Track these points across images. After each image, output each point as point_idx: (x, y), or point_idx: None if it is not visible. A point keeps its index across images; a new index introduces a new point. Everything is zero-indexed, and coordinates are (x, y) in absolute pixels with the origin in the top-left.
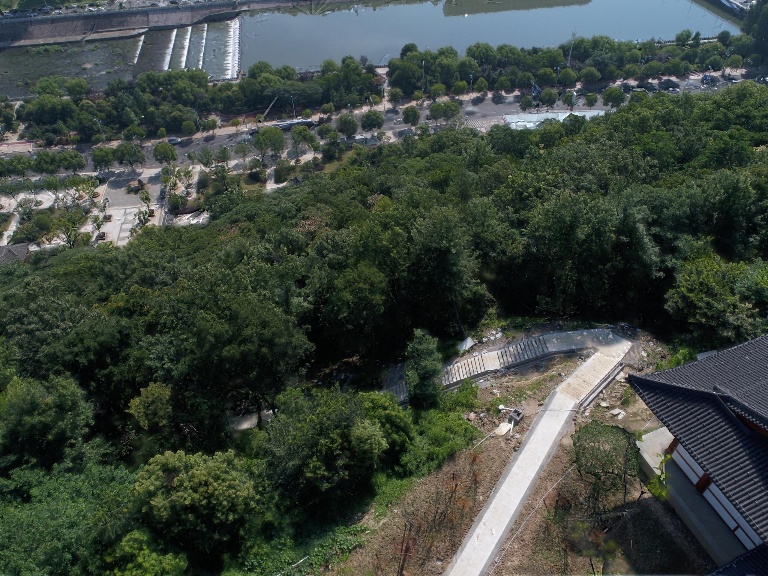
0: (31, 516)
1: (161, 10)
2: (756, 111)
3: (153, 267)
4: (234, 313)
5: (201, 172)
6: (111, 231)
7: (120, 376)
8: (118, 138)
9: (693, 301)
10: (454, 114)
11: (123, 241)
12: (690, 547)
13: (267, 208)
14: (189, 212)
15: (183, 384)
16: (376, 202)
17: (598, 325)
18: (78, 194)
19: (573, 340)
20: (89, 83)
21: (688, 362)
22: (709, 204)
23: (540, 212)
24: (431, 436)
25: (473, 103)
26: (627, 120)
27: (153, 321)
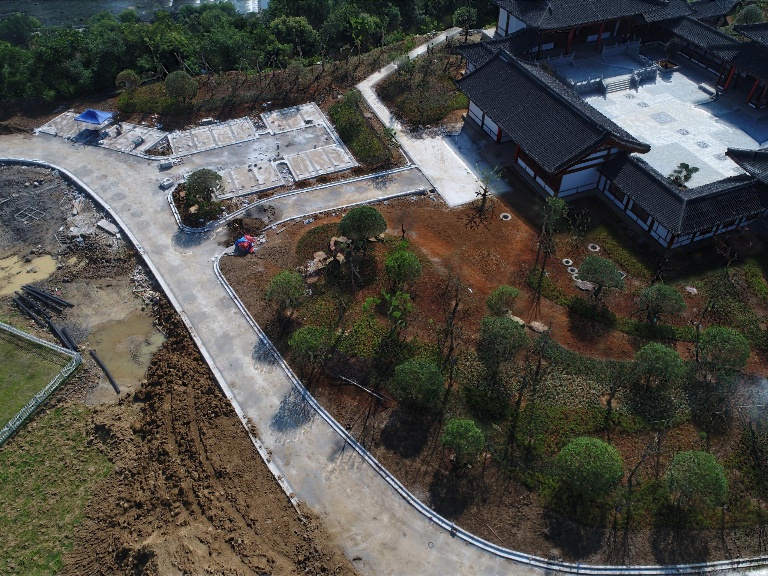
0: None
1: None
2: None
3: None
4: None
5: None
6: None
7: None
8: None
9: None
10: None
11: None
12: None
13: None
14: None
15: None
16: None
17: None
18: None
19: None
20: (139, 13)
21: None
22: None
23: None
24: None
25: None
26: None
27: None
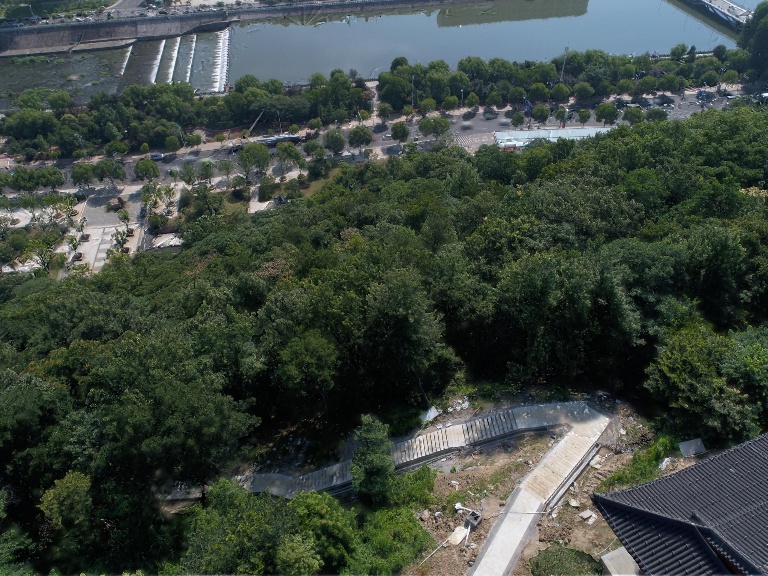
0: None
1: (150, 20)
2: (749, 146)
3: (102, 315)
4: (159, 398)
5: (183, 190)
6: (88, 251)
7: (38, 460)
8: (100, 153)
9: (675, 383)
10: (444, 130)
11: (99, 263)
12: None
13: (239, 238)
14: (169, 232)
15: (105, 473)
16: (349, 237)
17: (574, 395)
18: (55, 213)
19: (545, 415)
20: (72, 96)
21: (669, 452)
22: (696, 260)
23: (508, 275)
24: (376, 545)
25: (464, 118)
26: (615, 150)
27: (93, 381)
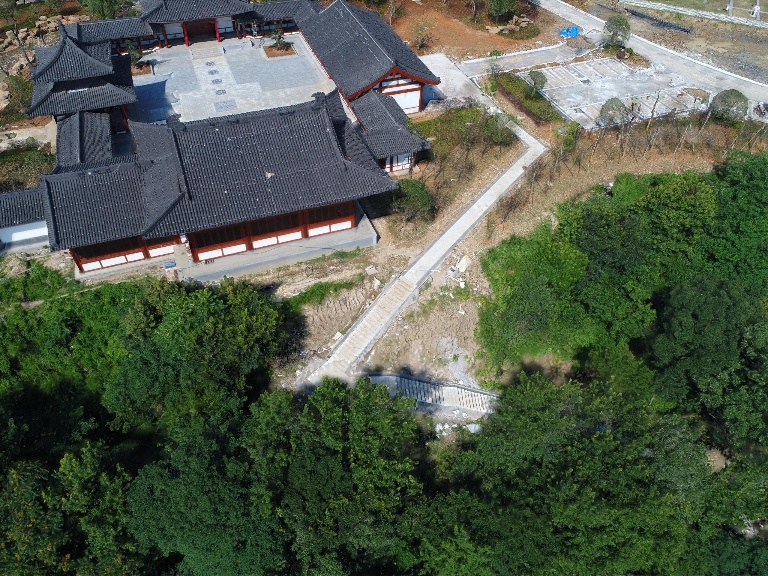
0: (761, 181)
1: None
2: None
3: None
4: None
5: None
6: None
7: None
8: None
9: None
10: None
11: None
12: (360, 199)
13: None
14: None
15: None
16: None
17: None
18: None
19: None
20: None
21: None
22: None
23: None
24: None
25: None
26: None
27: None
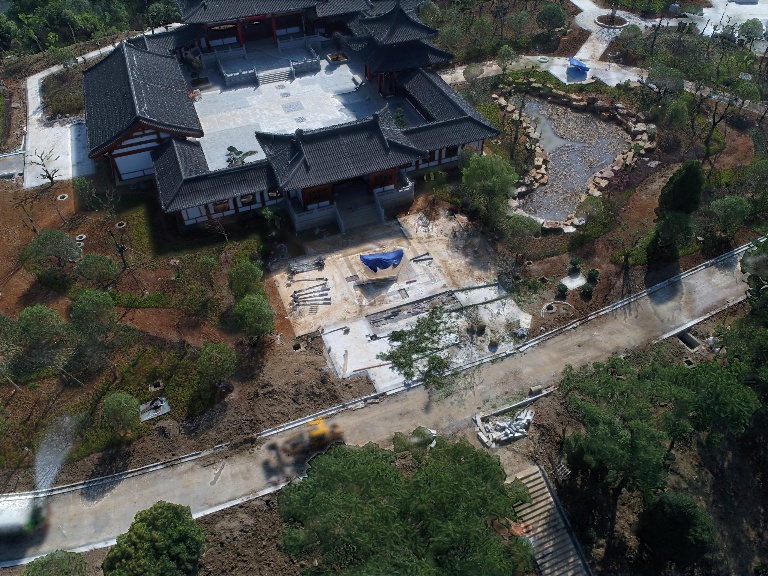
0: None
1: None
2: None
3: None
4: None
5: None
6: None
7: None
8: None
9: None
10: None
11: None
12: None
13: None
14: None
15: None
16: None
17: None
18: None
19: None
20: None
21: None
22: None
23: None
24: None
25: None
26: None
27: None
